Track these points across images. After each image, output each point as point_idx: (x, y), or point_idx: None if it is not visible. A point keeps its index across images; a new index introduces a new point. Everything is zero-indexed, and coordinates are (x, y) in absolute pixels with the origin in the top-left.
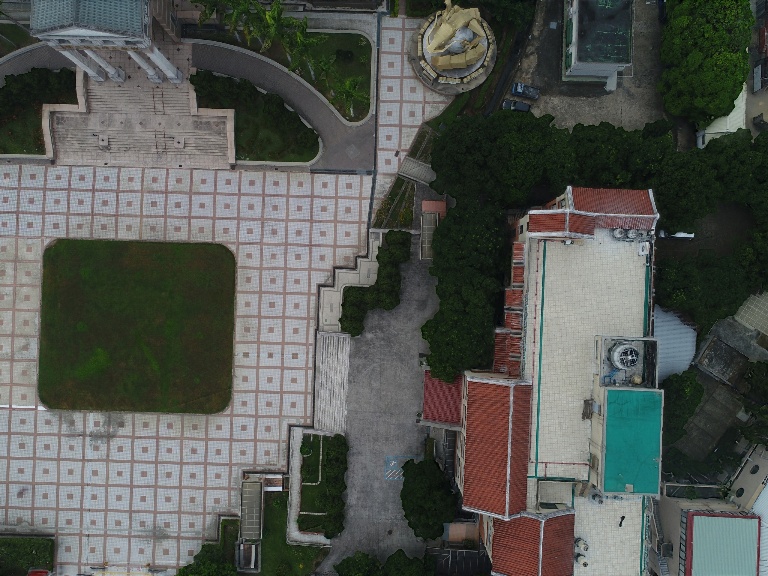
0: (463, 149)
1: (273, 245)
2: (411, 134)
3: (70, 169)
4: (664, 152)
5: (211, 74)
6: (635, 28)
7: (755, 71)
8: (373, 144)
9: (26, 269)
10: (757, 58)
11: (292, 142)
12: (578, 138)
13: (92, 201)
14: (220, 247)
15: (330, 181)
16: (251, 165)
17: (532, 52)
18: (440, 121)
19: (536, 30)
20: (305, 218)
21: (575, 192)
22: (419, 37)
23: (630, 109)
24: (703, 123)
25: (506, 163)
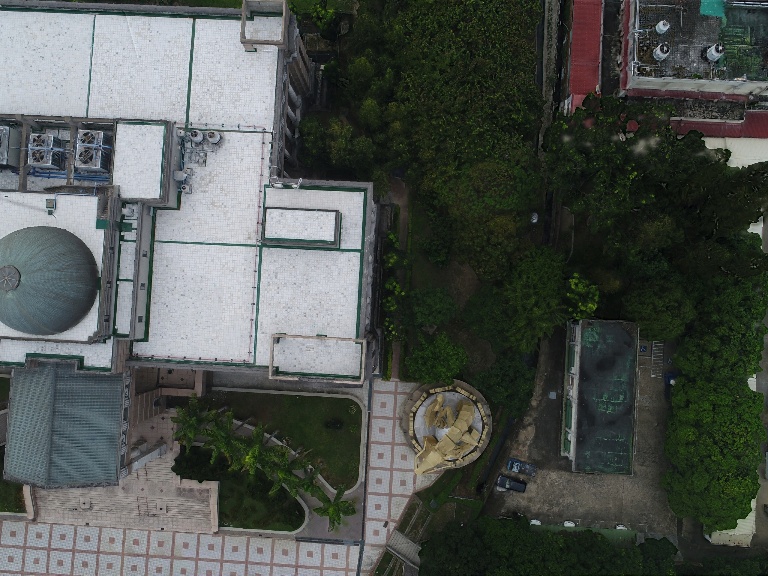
0: None
1: None
2: (401, 504)
3: (51, 527)
4: None
5: (194, 457)
6: (639, 402)
7: (767, 456)
8: (361, 513)
9: None
10: None
11: (277, 512)
12: None
13: (72, 562)
14: None
15: (316, 550)
16: (235, 531)
17: (530, 423)
18: (431, 498)
19: (534, 400)
20: None
21: None
22: (411, 415)
23: (632, 488)
24: (709, 531)
25: None
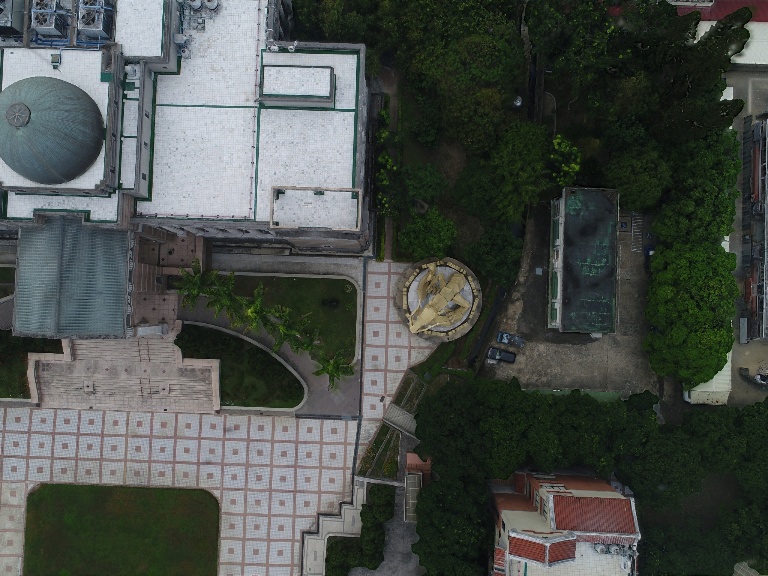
0: (446, 432)
1: (257, 491)
2: (396, 379)
3: (55, 412)
4: (648, 435)
5: (196, 332)
6: (621, 275)
7: (741, 321)
8: (358, 389)
9: (9, 514)
10: (743, 307)
11: (277, 389)
12: (561, 422)
13: (76, 445)
14: (204, 493)
15: (315, 426)
16: (236, 410)
17: (518, 298)
18: (425, 370)
19: (522, 276)
20: (290, 464)
21: (556, 502)
22: (404, 290)
23: (616, 357)
24: (688, 387)
25: (489, 449)
